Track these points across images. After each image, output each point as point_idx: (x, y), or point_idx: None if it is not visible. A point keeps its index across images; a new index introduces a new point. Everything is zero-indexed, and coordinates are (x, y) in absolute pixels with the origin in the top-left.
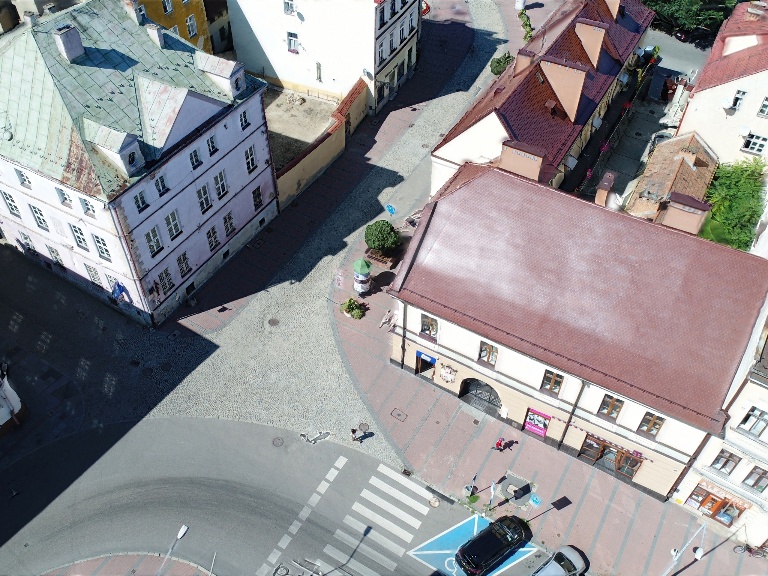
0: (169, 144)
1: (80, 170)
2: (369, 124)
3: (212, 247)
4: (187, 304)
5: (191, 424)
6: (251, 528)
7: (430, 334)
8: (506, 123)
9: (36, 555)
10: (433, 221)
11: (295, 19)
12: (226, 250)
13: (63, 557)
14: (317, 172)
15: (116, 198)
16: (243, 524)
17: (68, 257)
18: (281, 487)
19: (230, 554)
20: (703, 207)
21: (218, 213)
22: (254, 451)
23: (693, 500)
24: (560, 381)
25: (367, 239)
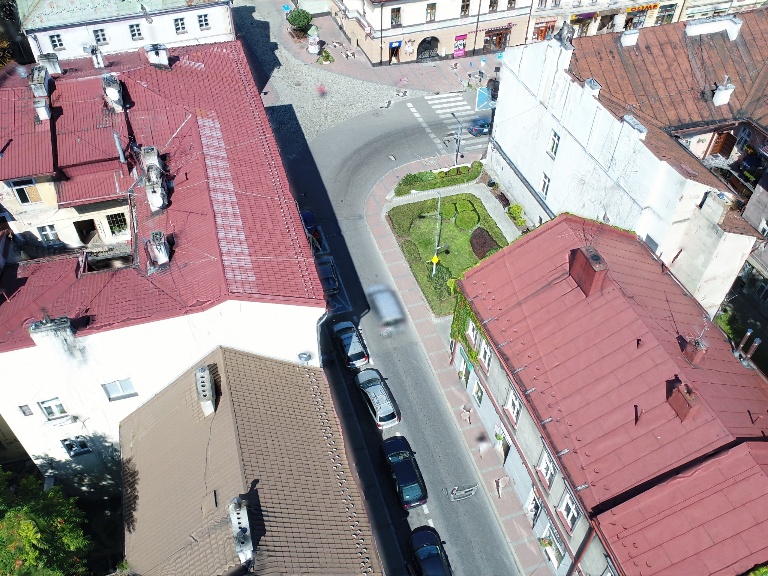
0: None
1: None
2: None
3: None
4: None
5: (332, 132)
6: (414, 141)
7: (396, 24)
8: None
9: (352, 200)
10: None
11: None
12: None
13: (364, 193)
14: None
15: None
16: (410, 142)
17: None
18: (403, 125)
19: (421, 151)
20: None
21: None
22: (373, 122)
23: (534, 40)
24: (469, 4)
25: (298, 22)
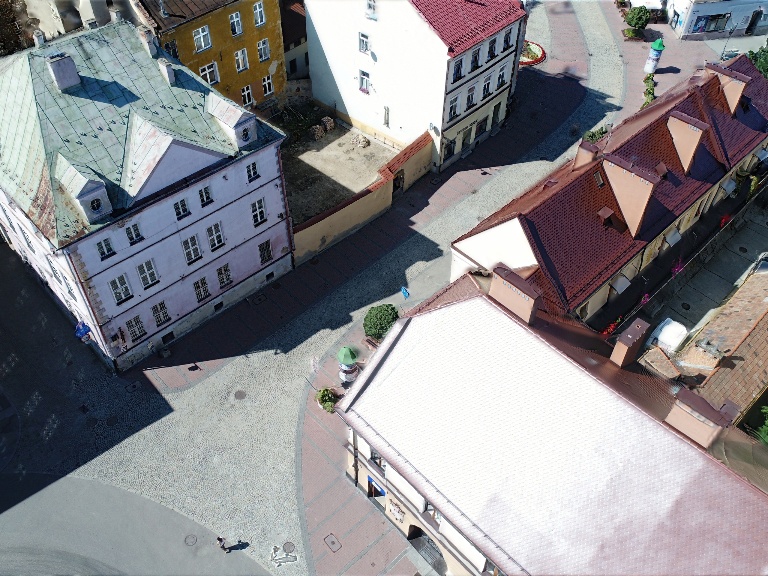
0: (146, 193)
1: (43, 207)
2: (428, 182)
3: (201, 298)
4: (159, 354)
5: (111, 494)
6: None
7: (380, 464)
8: (531, 233)
9: None
10: (402, 339)
11: (368, 58)
12: (219, 302)
13: None
14: (350, 229)
15: (68, 245)
16: None
17: (51, 282)
18: None
19: None
20: (716, 420)
21: (210, 265)
22: (162, 544)
23: None
24: None
25: (365, 323)
